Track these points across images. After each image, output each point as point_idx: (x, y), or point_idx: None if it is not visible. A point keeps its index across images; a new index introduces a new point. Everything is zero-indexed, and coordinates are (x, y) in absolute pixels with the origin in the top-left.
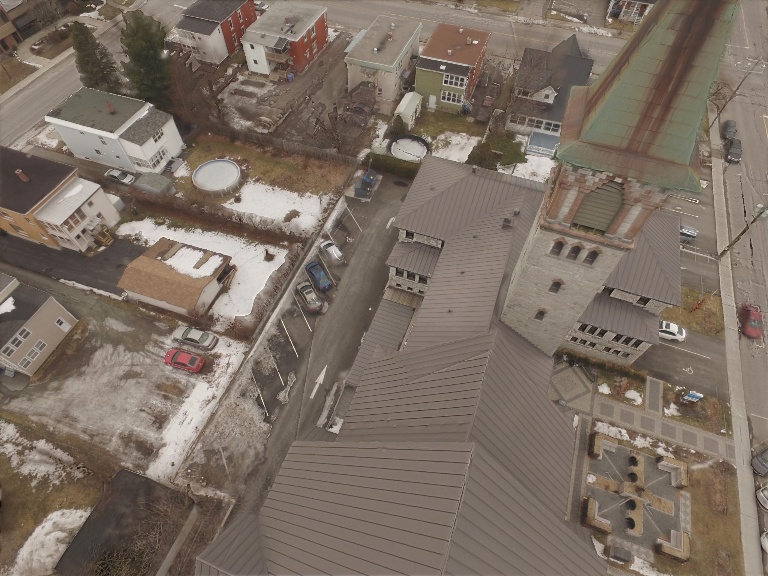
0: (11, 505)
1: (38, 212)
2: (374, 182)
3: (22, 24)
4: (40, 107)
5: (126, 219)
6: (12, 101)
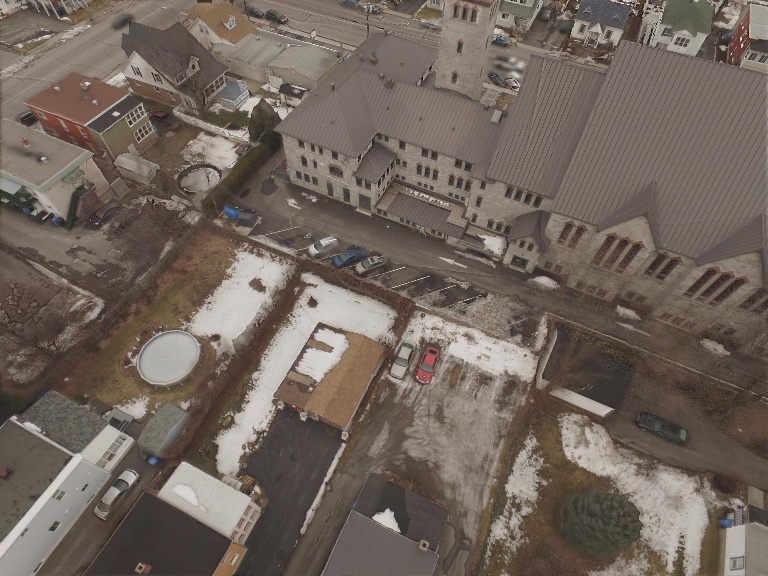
0: None
1: None
2: None
3: None
4: None
5: (210, 468)
6: None
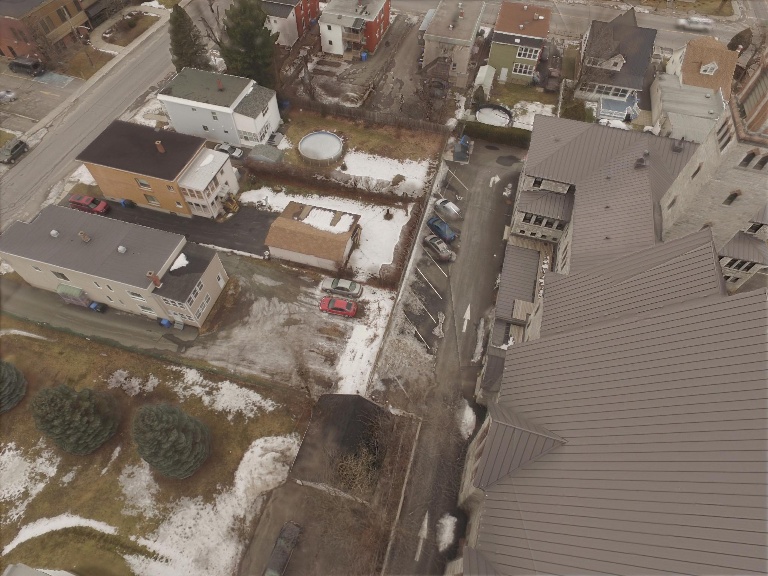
0: (215, 436)
1: (180, 180)
2: (468, 147)
3: (94, 13)
4: (128, 91)
5: (245, 188)
6: (98, 86)
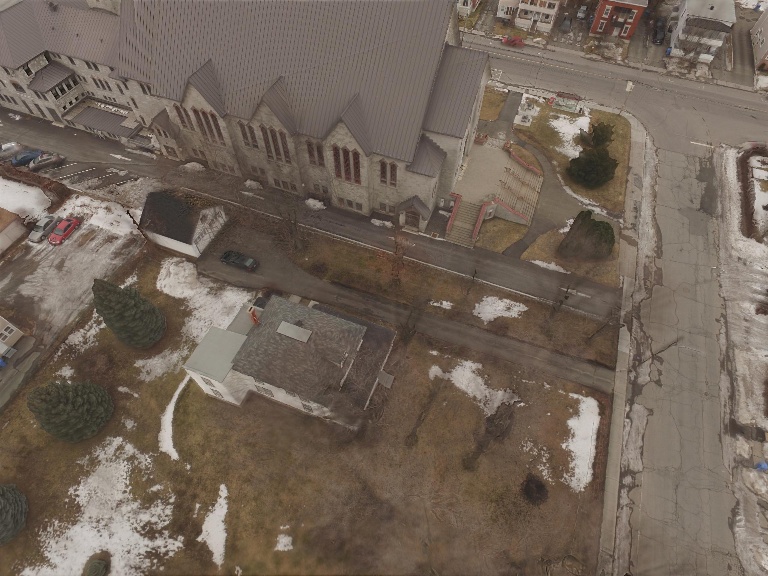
0: None
1: None
2: None
3: None
4: None
5: None
6: None
